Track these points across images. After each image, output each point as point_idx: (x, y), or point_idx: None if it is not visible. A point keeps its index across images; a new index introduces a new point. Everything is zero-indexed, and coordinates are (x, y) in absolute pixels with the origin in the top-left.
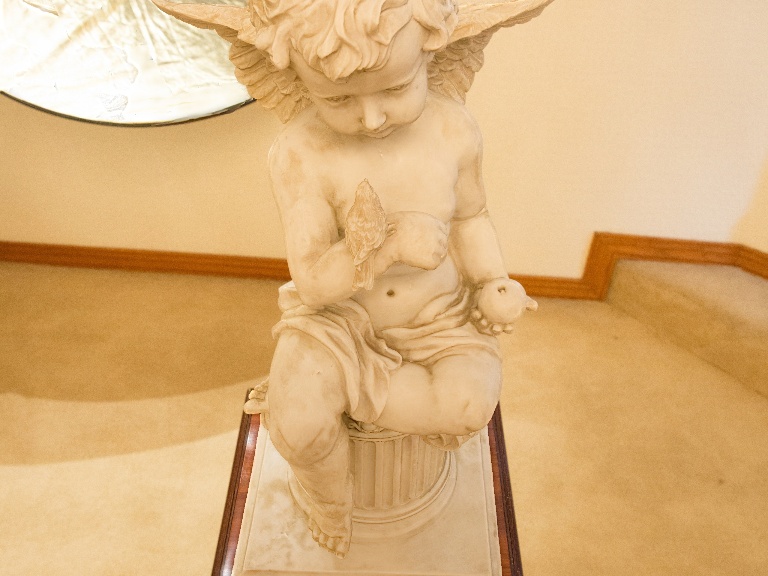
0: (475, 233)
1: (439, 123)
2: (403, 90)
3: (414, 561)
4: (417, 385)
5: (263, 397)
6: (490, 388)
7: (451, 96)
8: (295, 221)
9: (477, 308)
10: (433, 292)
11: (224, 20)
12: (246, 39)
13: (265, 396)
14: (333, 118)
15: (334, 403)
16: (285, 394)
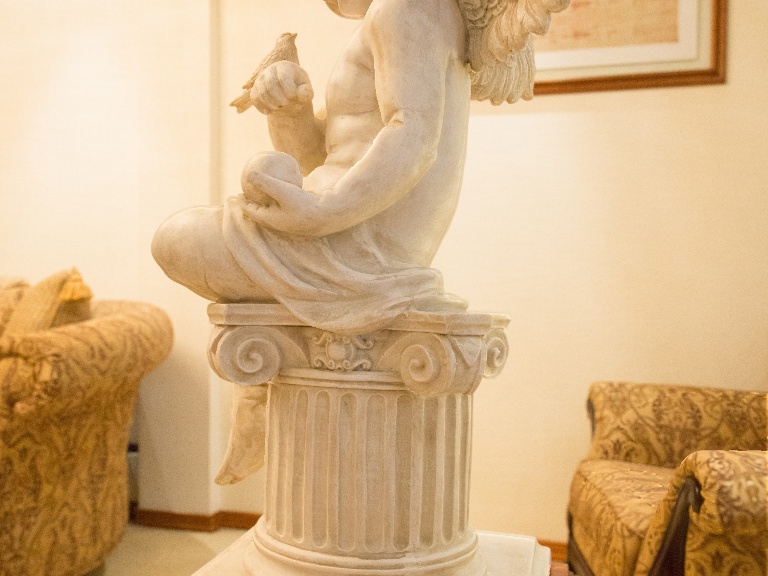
0: None
1: None
2: None
3: (208, 573)
4: None
5: None
6: (175, 219)
7: None
8: None
9: None
10: None
11: None
12: None
13: None
14: None
15: None
16: None
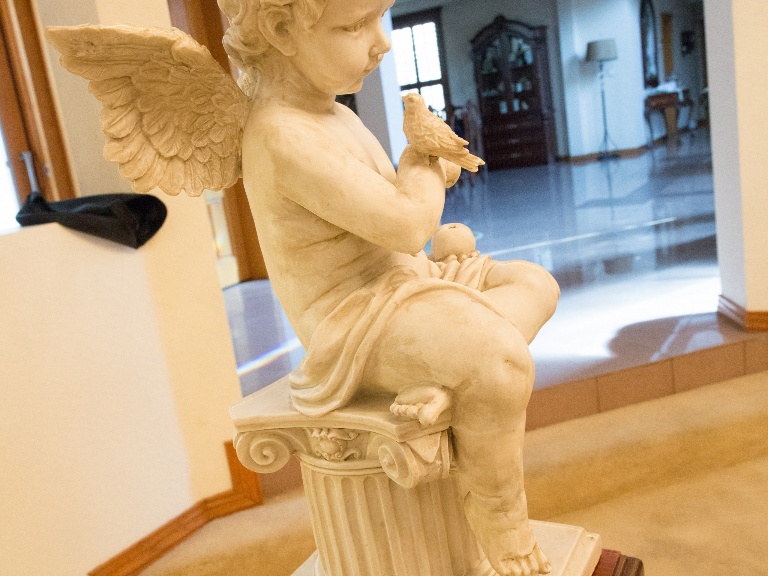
0: None
1: (342, 108)
2: None
3: None
4: (507, 291)
5: (422, 404)
6: None
7: None
8: (359, 175)
9: (446, 256)
10: None
11: (158, 32)
12: (190, 46)
13: (428, 395)
14: (354, 52)
15: None
16: (480, 326)
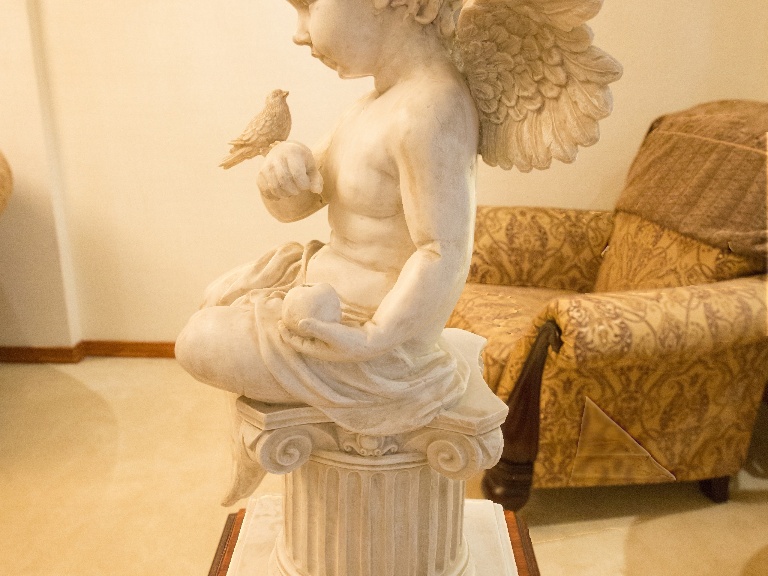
0: (406, 264)
1: None
2: (309, 8)
3: None
4: None
5: None
6: (203, 333)
7: (542, 132)
8: None
9: None
10: (327, 278)
11: None
12: None
13: None
14: None
15: (224, 292)
16: None
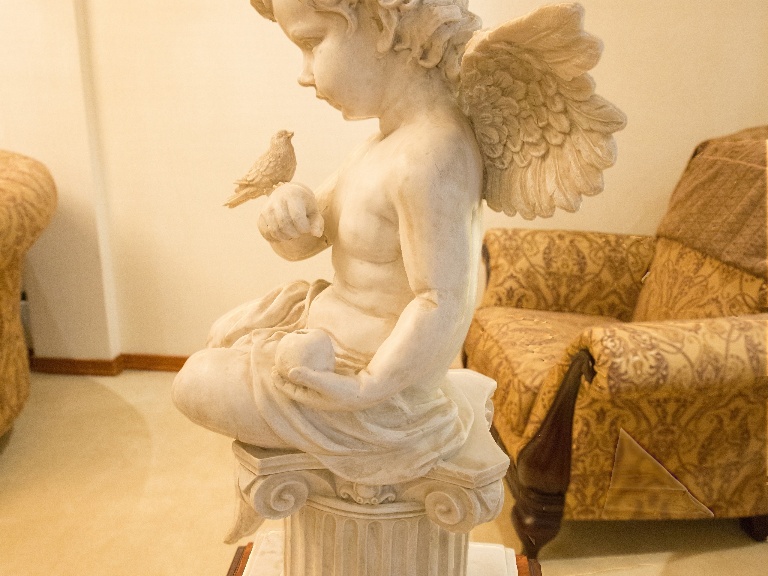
0: (403, 312)
1: (402, 140)
2: (313, 51)
3: None
4: None
5: None
6: (198, 376)
7: (546, 179)
8: None
9: None
10: (326, 322)
11: None
12: None
13: None
14: None
15: None
16: None
